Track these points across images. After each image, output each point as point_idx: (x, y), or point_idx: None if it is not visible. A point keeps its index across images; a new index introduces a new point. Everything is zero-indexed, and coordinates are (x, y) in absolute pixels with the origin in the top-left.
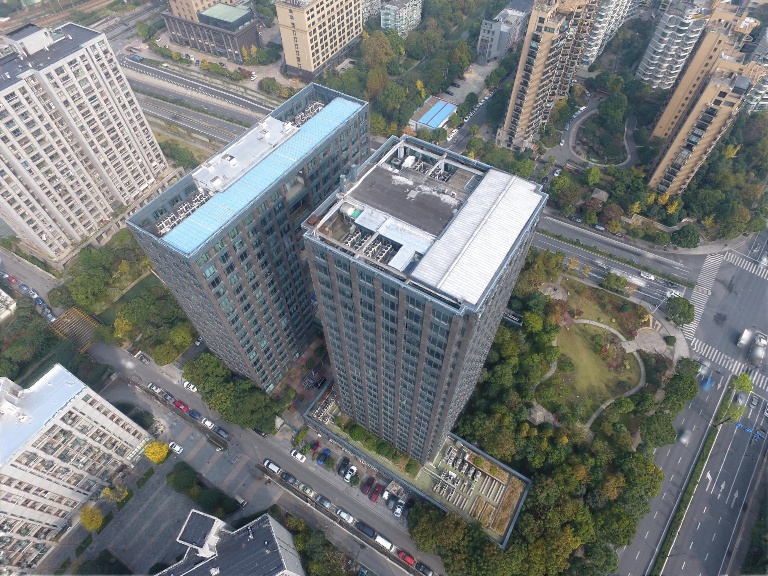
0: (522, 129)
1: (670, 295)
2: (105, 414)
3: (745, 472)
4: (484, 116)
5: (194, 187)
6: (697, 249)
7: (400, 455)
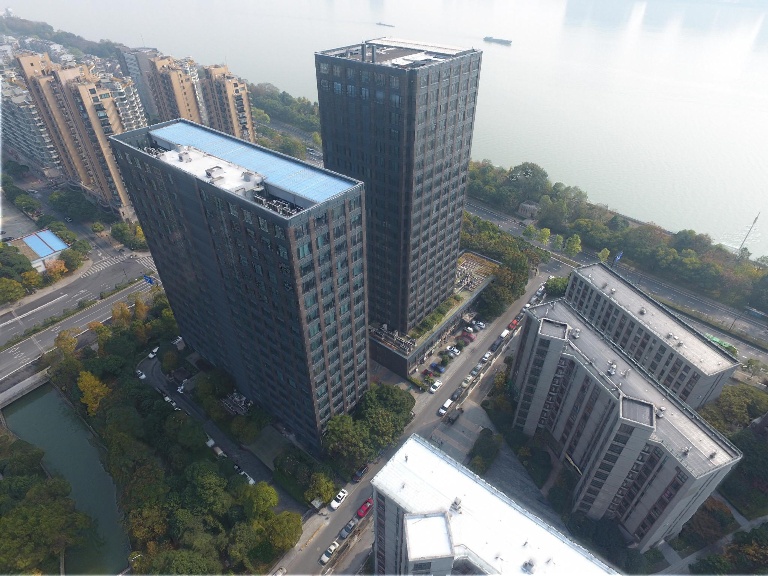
0: None
1: None
2: None
3: None
4: (75, 226)
5: None
6: None
7: None
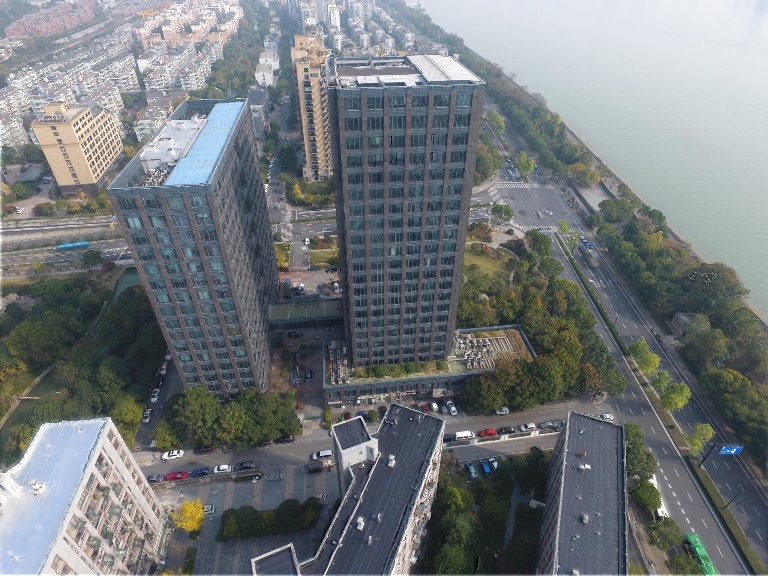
0: (322, 160)
1: (493, 203)
2: (127, 469)
3: (603, 270)
4: (280, 171)
5: (143, 171)
6: (479, 188)
7: (426, 363)
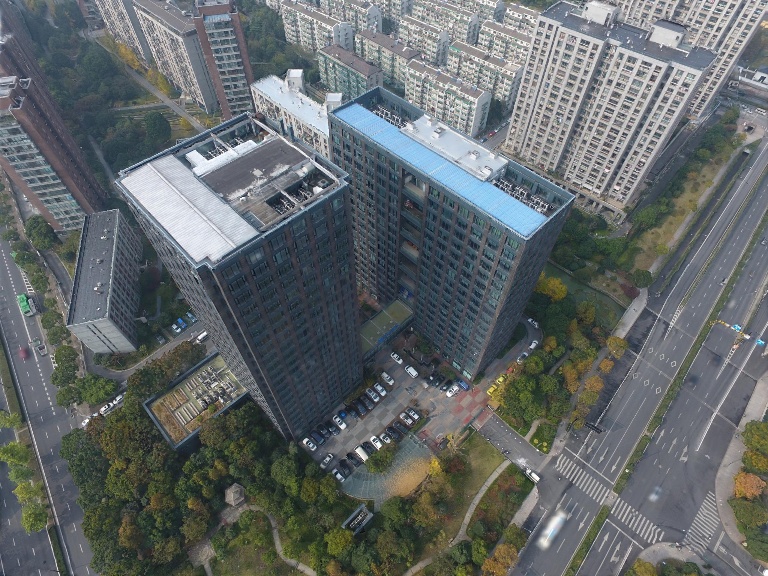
0: None
1: None
2: None
3: None
4: None
5: None
6: None
7: None
